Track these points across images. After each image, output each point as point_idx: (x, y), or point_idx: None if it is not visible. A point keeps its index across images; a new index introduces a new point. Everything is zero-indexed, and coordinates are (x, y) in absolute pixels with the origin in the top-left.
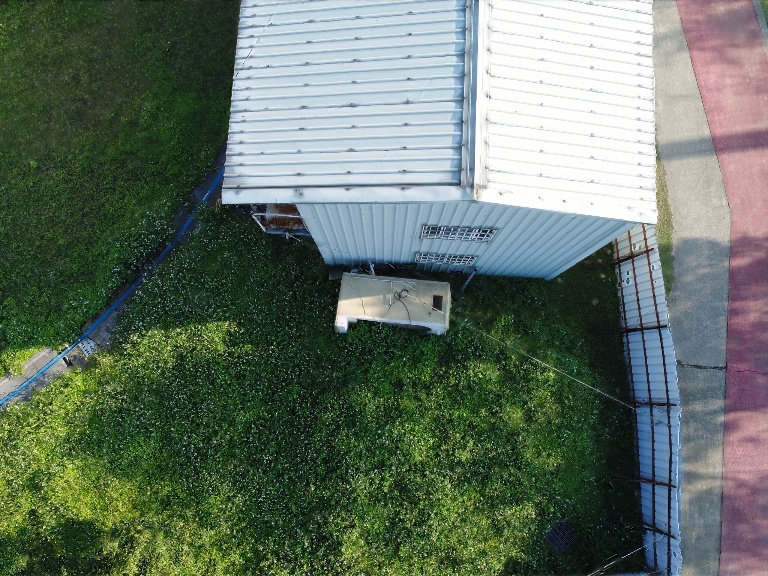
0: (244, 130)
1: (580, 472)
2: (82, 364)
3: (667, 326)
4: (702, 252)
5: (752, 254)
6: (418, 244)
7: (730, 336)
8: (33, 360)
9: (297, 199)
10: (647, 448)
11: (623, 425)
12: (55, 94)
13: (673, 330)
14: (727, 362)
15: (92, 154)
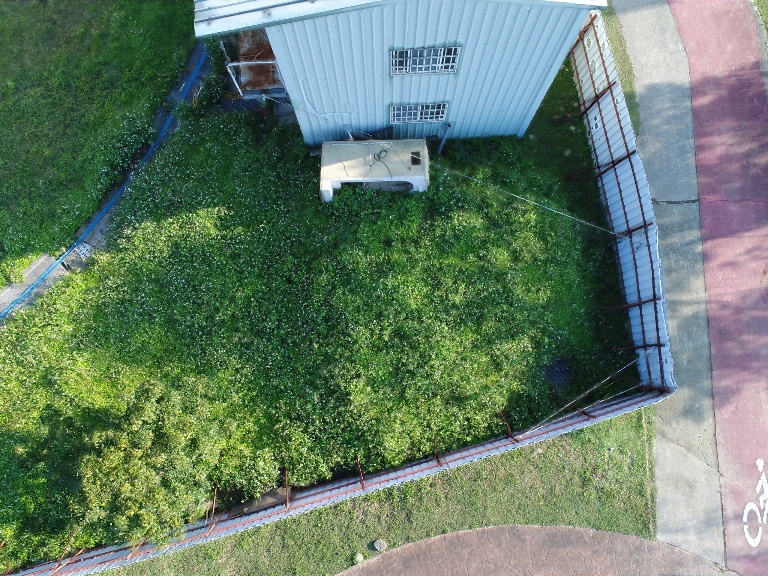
0: None
1: (570, 305)
2: (81, 267)
3: (636, 151)
4: (664, 96)
5: (712, 92)
6: (389, 89)
7: (699, 170)
8: (32, 268)
9: (266, 19)
10: (631, 277)
11: (607, 262)
12: (24, 17)
13: (645, 171)
14: (699, 195)
15: (67, 69)
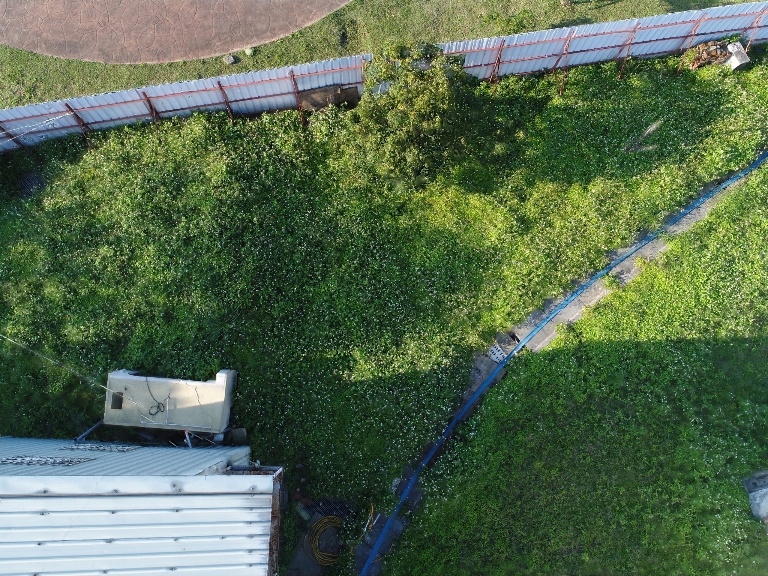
0: (248, 568)
1: None
2: (501, 337)
3: None
4: None
5: None
6: None
7: None
8: (549, 339)
9: (179, 480)
10: None
11: None
12: None
13: None
14: None
15: (522, 572)
